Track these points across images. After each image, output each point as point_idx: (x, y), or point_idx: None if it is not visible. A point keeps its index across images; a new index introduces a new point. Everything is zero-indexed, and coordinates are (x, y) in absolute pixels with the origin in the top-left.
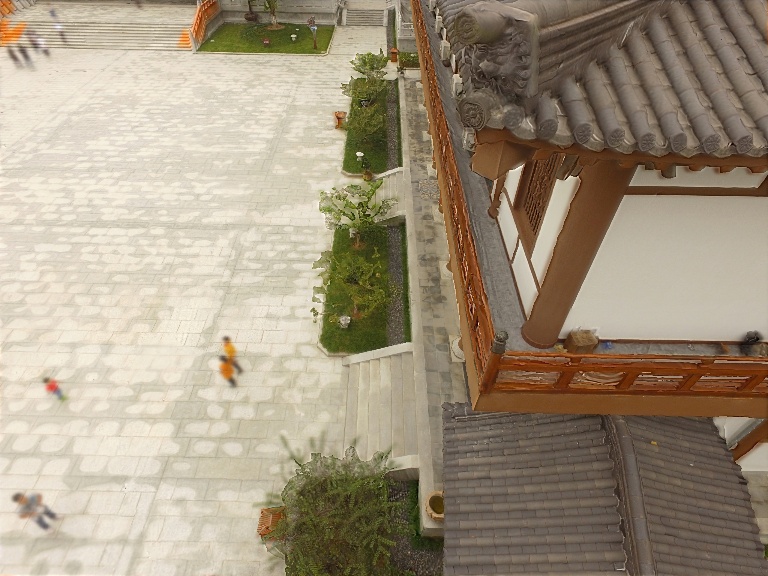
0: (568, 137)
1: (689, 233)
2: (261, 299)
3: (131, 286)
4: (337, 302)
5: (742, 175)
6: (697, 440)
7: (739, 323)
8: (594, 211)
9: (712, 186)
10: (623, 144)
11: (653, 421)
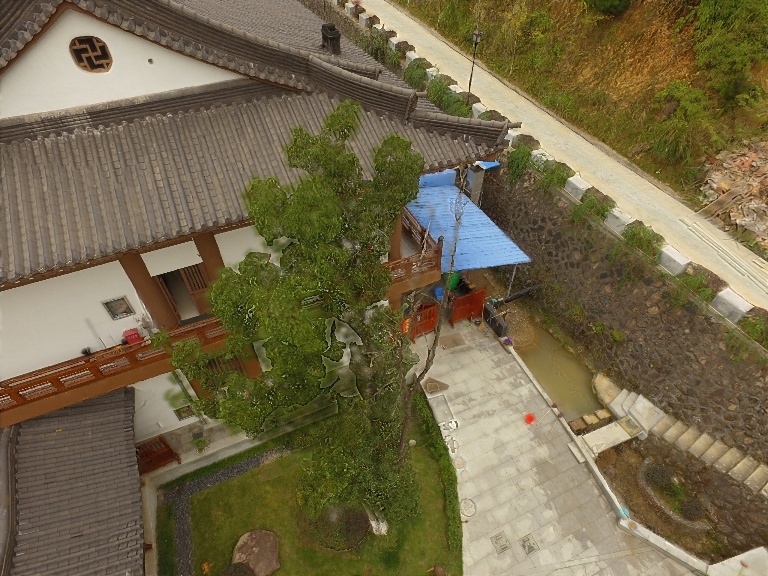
0: None
1: None
2: None
3: None
4: None
5: None
6: (105, 415)
7: (68, 348)
8: None
9: None
10: None
11: (65, 416)
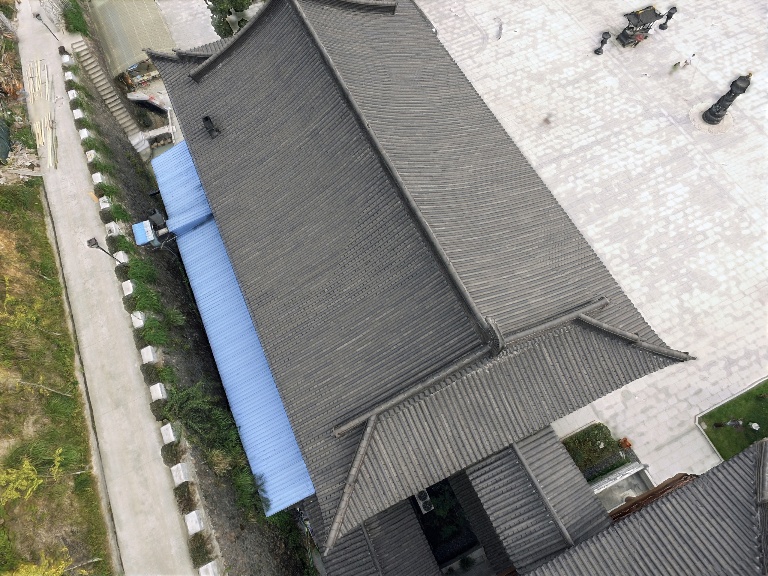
0: None
1: None
2: None
3: (543, 124)
4: None
5: None
6: None
7: None
8: None
9: None
10: None
11: None
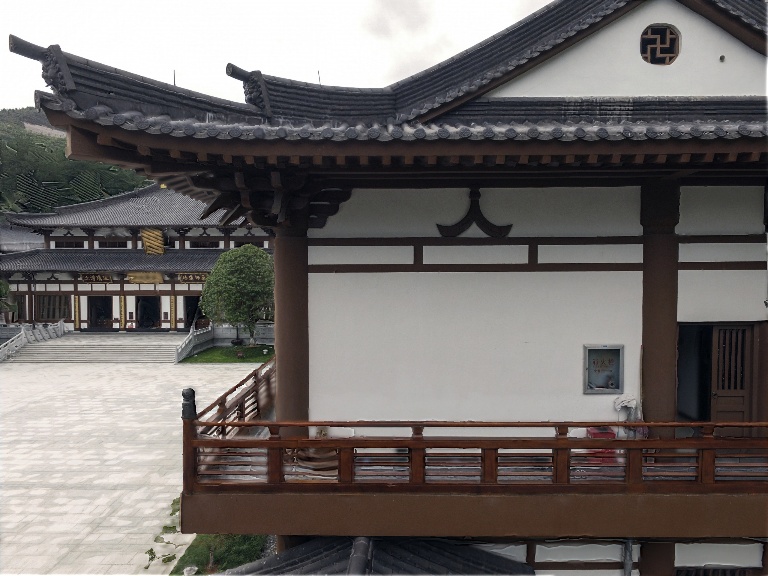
0: (107, 120)
1: (381, 311)
2: (108, 557)
3: None
4: (194, 555)
5: (393, 252)
6: None
7: None
8: (284, 286)
9: (376, 263)
10: (149, 128)
11: None
